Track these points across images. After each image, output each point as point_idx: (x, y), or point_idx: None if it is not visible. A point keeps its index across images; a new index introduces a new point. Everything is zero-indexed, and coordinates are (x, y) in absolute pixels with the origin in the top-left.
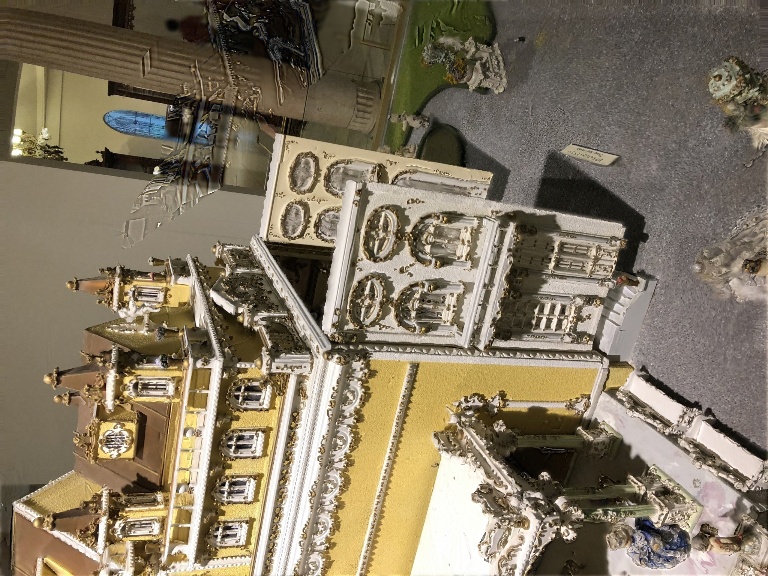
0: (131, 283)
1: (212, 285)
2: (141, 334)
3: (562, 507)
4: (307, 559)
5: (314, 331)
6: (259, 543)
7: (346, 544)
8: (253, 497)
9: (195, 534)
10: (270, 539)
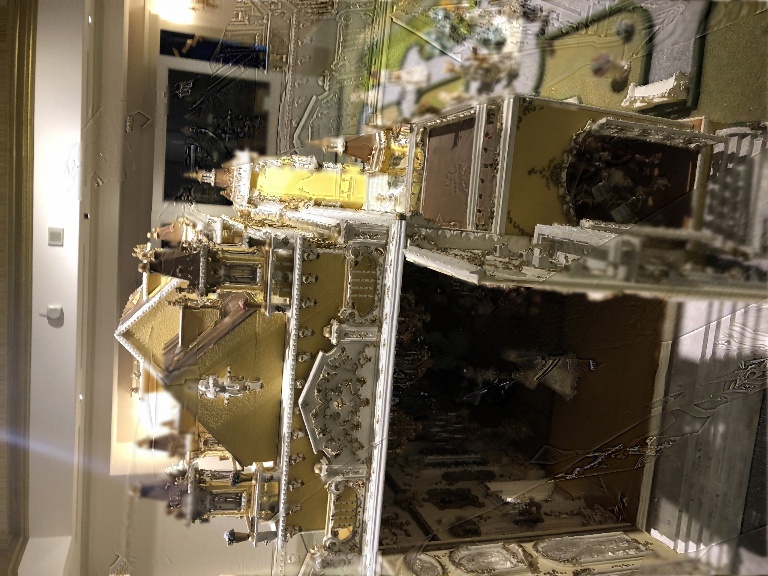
0: (217, 289)
1: (312, 332)
2: (221, 397)
3: None
4: None
5: None
6: None
7: None
8: None
9: None
10: None
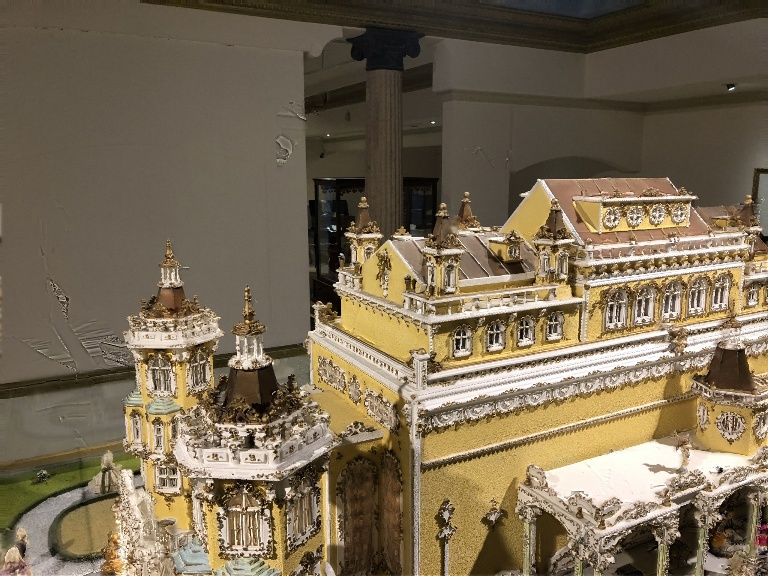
0: None
1: None
2: None
3: None
4: (764, 341)
5: None
6: (765, 311)
7: (764, 362)
8: (767, 302)
9: (765, 275)
10: (767, 317)
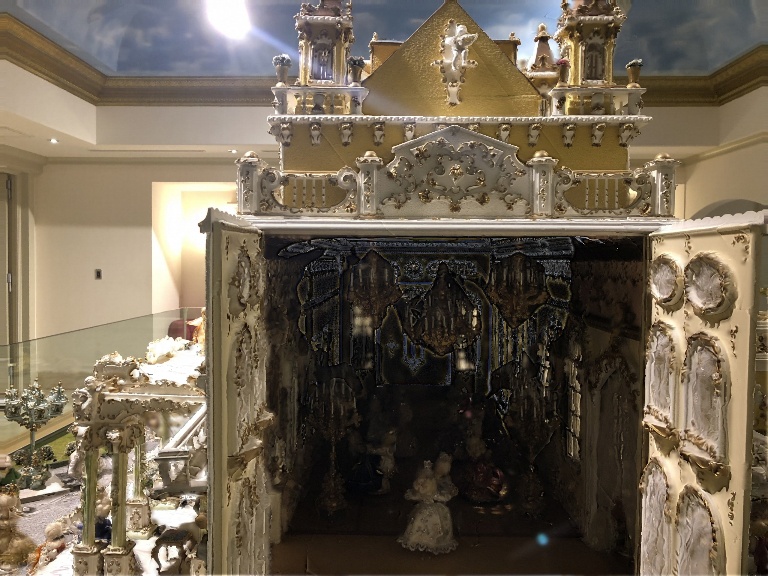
0: (573, 40)
1: (533, 144)
2: None
3: (76, 427)
4: None
5: (270, 221)
6: None
7: None
8: None
9: None
10: None
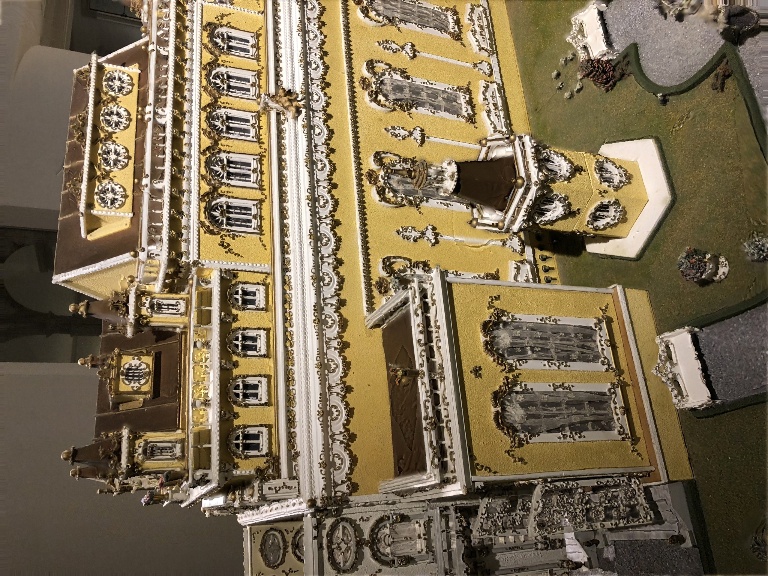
0: None
1: None
2: None
3: None
4: None
5: None
6: None
7: None
8: None
9: None
10: None
